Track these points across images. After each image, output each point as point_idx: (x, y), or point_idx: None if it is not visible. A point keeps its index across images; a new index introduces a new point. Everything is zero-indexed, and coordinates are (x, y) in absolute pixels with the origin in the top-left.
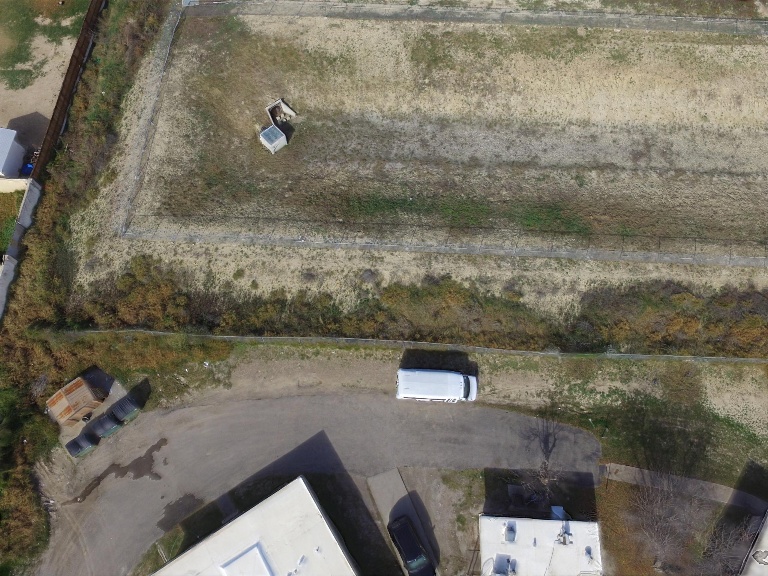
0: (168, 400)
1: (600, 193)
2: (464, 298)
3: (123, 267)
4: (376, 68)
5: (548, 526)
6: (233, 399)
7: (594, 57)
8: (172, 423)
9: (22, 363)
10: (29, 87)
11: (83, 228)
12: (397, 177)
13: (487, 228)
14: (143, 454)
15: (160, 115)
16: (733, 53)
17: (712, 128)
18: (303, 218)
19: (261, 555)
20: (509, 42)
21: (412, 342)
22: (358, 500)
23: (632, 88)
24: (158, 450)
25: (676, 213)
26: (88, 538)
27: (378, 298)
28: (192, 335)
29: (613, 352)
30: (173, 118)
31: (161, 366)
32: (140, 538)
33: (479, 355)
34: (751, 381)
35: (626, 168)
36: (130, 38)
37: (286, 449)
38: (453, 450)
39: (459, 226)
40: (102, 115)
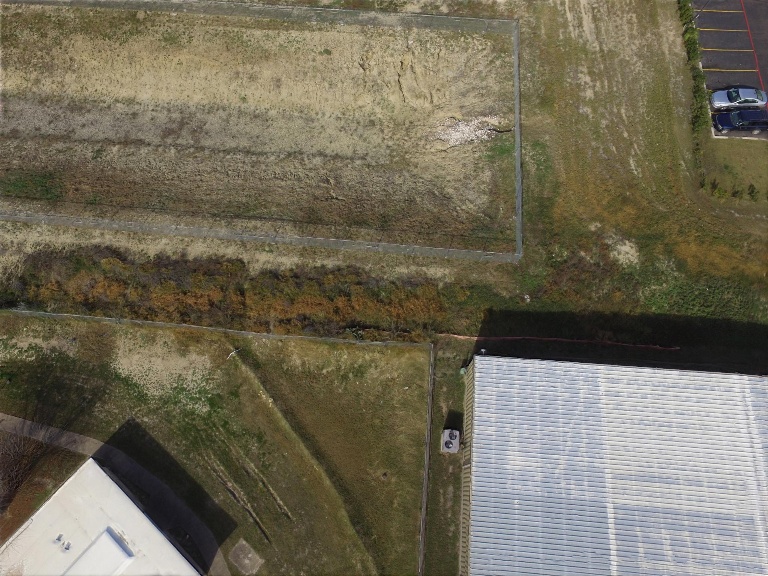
0: None
1: (105, 165)
2: None
3: None
4: None
5: None
6: None
7: (147, 39)
8: None
9: None
10: None
11: None
12: None
13: None
14: None
15: None
16: (279, 38)
17: (249, 109)
18: None
19: None
20: (71, 23)
21: None
22: None
23: (179, 69)
24: None
25: (160, 186)
26: None
27: None
28: None
29: (19, 309)
30: None
31: None
32: None
33: None
34: (163, 345)
35: (151, 144)
36: None
37: None
38: None
39: None
40: None
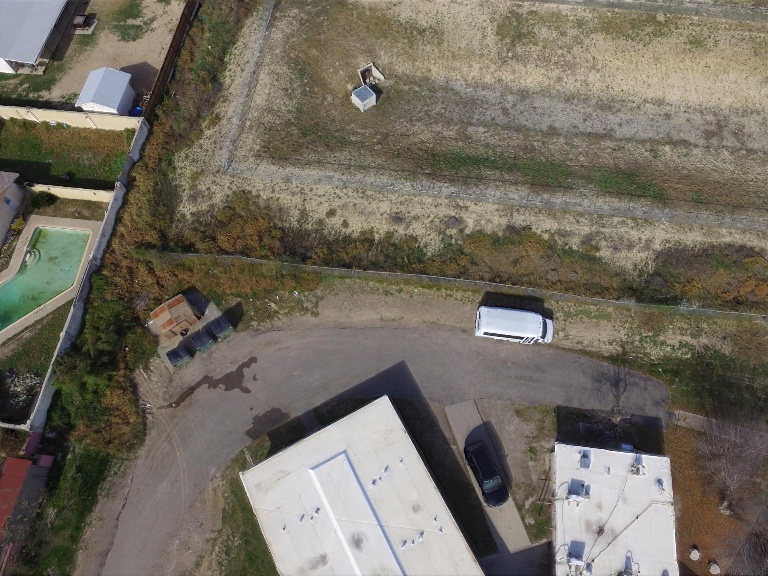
0: (259, 323)
1: (674, 165)
2: (543, 248)
3: (224, 200)
4: (462, 40)
5: (622, 457)
6: (320, 326)
7: (671, 41)
8: (262, 343)
9: (128, 279)
10: (139, 40)
11: (187, 164)
12: (479, 139)
13: (566, 187)
14: (235, 369)
15: (262, 69)
16: None
17: None
18: (392, 168)
19: (348, 461)
20: (590, 23)
21: (493, 284)
22: (435, 425)
23: (707, 72)
24: (249, 366)
25: (748, 187)
26: (181, 440)
27: (461, 244)
28: (287, 263)
29: (687, 306)
30: (274, 72)
31: (254, 292)
32: (230, 443)
33: (555, 303)
34: None
35: (699, 145)
36: (235, 1)
37: (369, 374)
38: (527, 387)
39: (540, 184)
40: (208, 66)
